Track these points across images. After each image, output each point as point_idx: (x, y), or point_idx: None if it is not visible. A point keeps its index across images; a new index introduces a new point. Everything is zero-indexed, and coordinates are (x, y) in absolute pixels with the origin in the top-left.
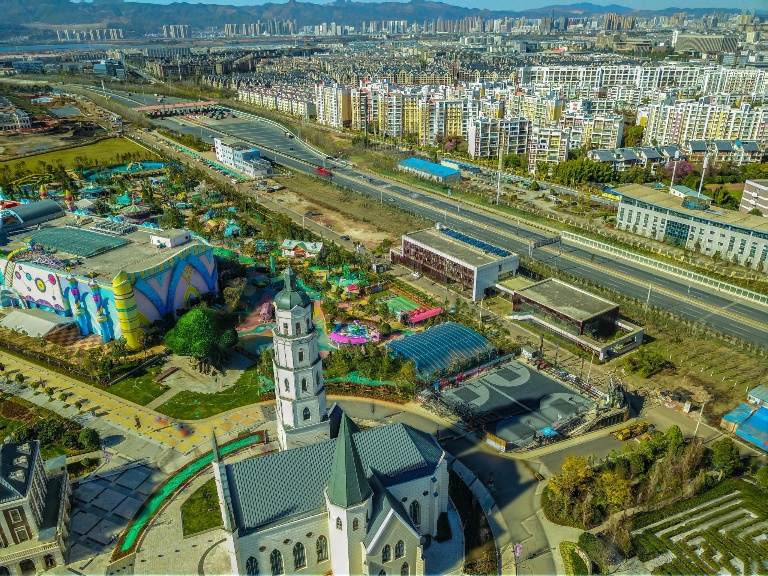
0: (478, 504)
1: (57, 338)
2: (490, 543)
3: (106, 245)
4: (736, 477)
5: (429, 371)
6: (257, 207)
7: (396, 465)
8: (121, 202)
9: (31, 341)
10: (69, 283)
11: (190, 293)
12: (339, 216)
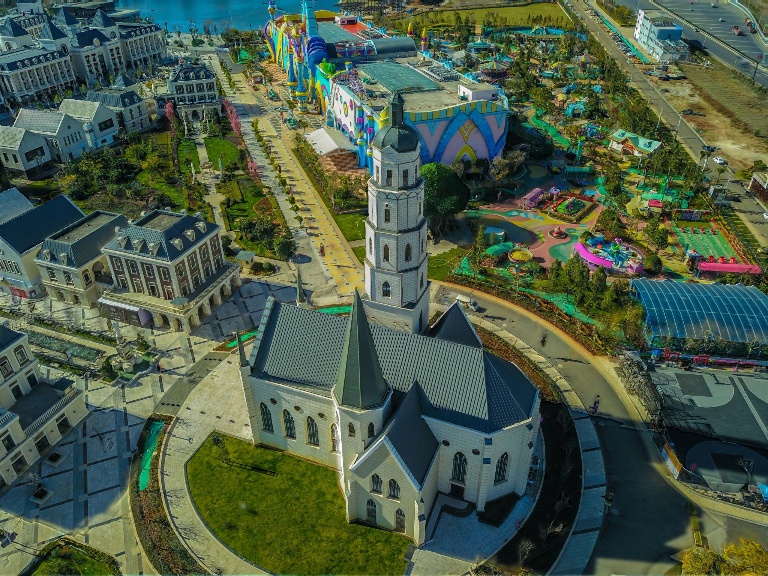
0: (572, 514)
1: (340, 162)
2: (540, 565)
3: (416, 85)
4: None
5: (657, 331)
6: (628, 91)
7: (448, 397)
8: (492, 60)
9: (321, 158)
10: (358, 110)
11: (465, 154)
12: (726, 122)
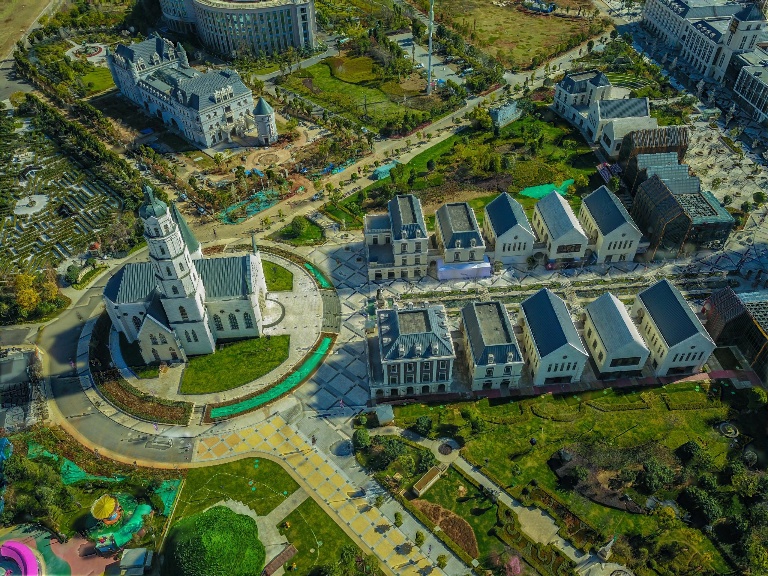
0: None
1: None
2: None
3: None
4: None
5: (2, 440)
6: None
7: None
8: None
9: None
10: None
11: None
12: None
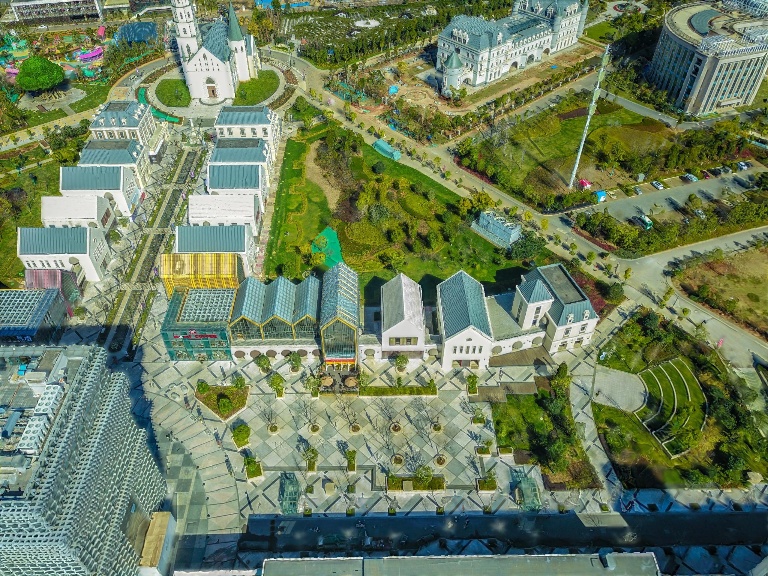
0: None
1: None
2: None
3: None
4: (281, 14)
5: (155, 40)
6: None
7: None
8: None
9: None
10: None
11: None
12: None
